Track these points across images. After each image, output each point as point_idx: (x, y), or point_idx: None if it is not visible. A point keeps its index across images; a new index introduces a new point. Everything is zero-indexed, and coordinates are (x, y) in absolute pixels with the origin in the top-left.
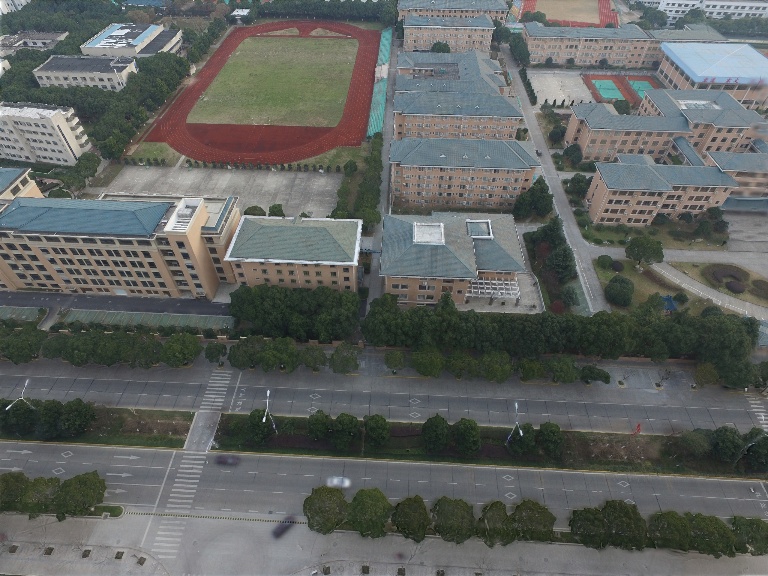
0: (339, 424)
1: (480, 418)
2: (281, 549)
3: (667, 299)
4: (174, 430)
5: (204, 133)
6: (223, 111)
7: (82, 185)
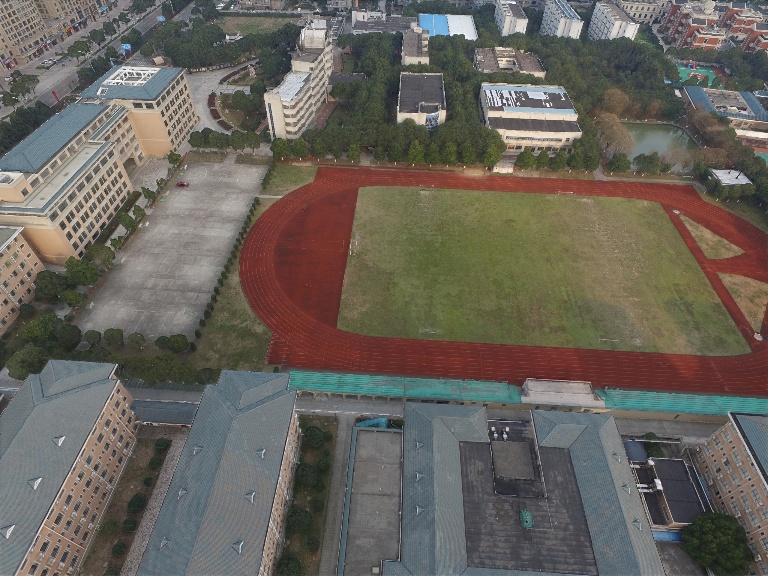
0: None
1: None
2: None
3: None
4: None
5: (332, 203)
6: (390, 210)
7: (220, 146)
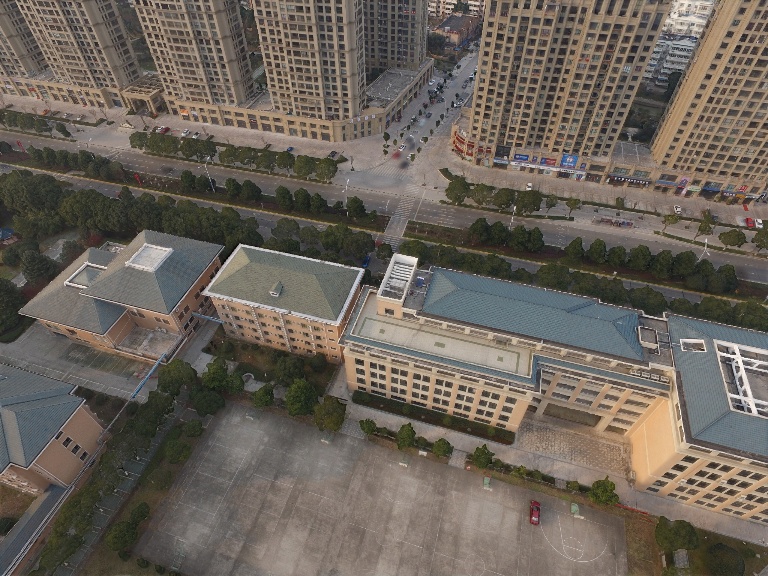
0: (306, 192)
1: (217, 207)
2: (355, 179)
3: (3, 230)
4: (416, 228)
5: None
6: None
7: None
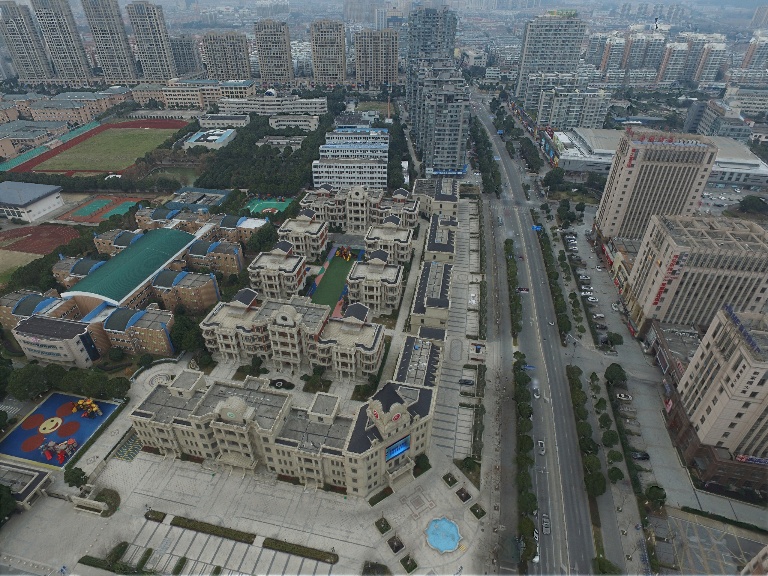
0: None
1: None
2: None
3: None
4: None
5: None
6: (162, 132)
7: None
